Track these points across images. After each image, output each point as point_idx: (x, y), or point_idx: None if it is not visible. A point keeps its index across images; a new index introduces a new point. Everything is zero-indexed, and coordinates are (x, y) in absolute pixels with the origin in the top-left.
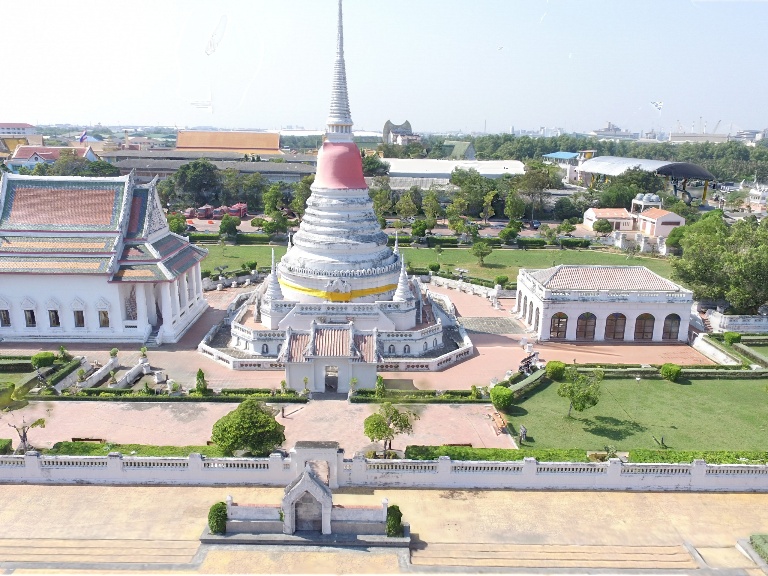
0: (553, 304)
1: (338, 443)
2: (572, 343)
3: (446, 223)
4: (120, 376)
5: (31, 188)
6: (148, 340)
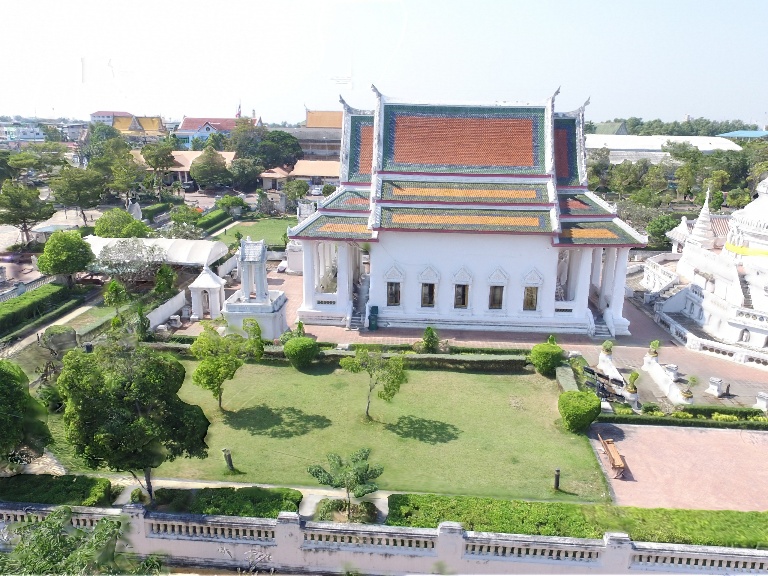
0: None
1: None
2: None
3: None
4: (640, 383)
5: (416, 116)
6: (595, 330)
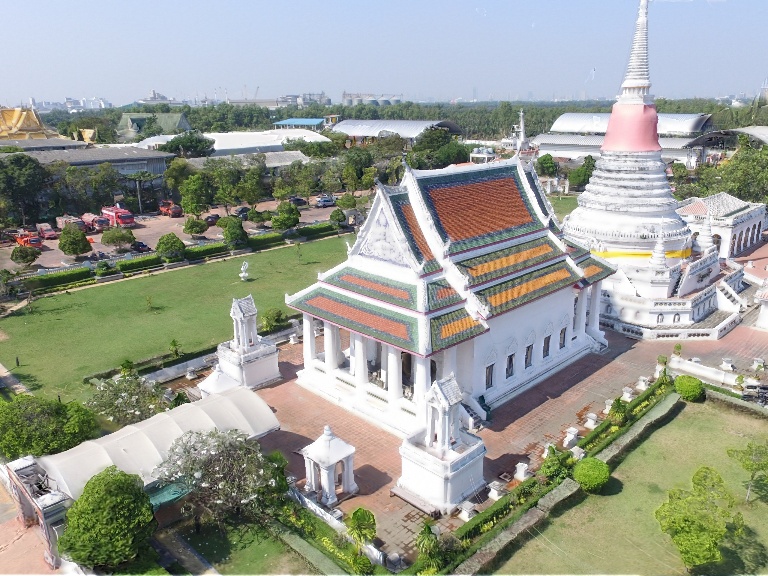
0: (734, 228)
1: None
2: (740, 256)
3: (362, 195)
4: None
5: (443, 188)
6: None
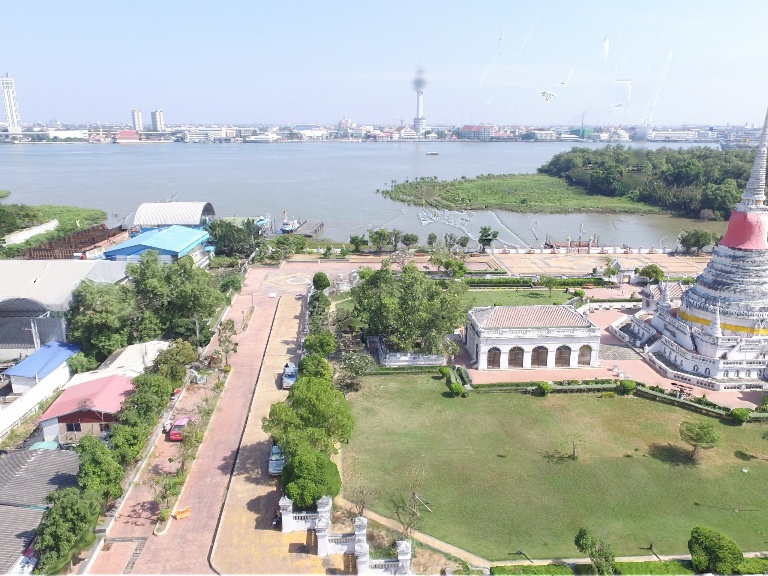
0: None
1: (621, 270)
2: None
3: None
4: None
5: None
6: None
